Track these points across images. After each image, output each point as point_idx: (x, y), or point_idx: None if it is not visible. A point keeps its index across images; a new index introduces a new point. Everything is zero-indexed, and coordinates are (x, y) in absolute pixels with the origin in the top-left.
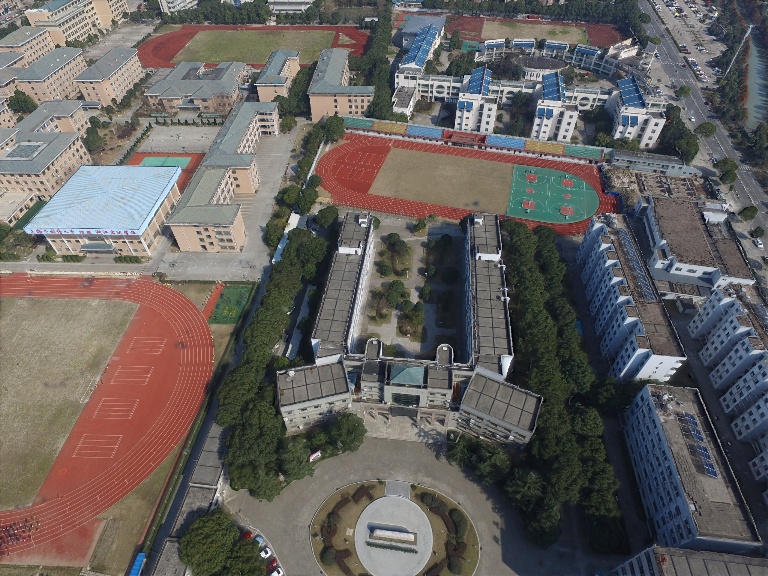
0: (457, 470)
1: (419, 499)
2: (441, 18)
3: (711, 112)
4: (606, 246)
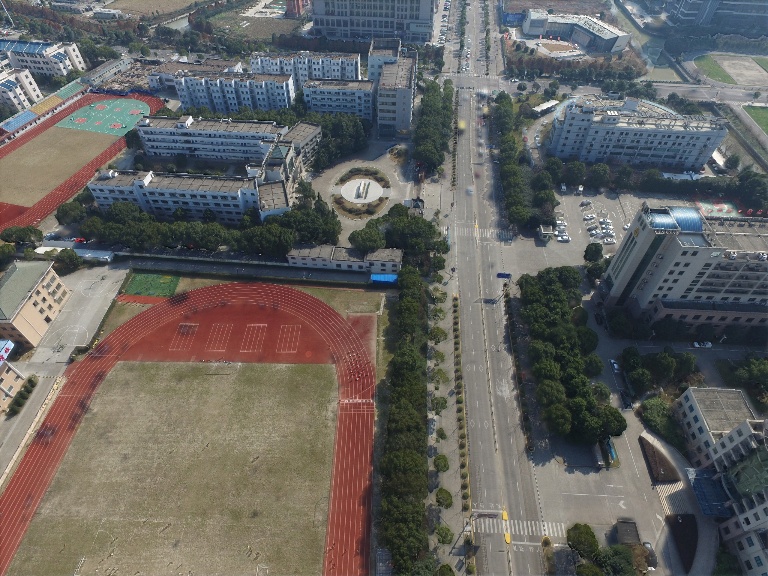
0: (329, 170)
1: (343, 182)
2: None
3: (59, 42)
4: (203, 81)
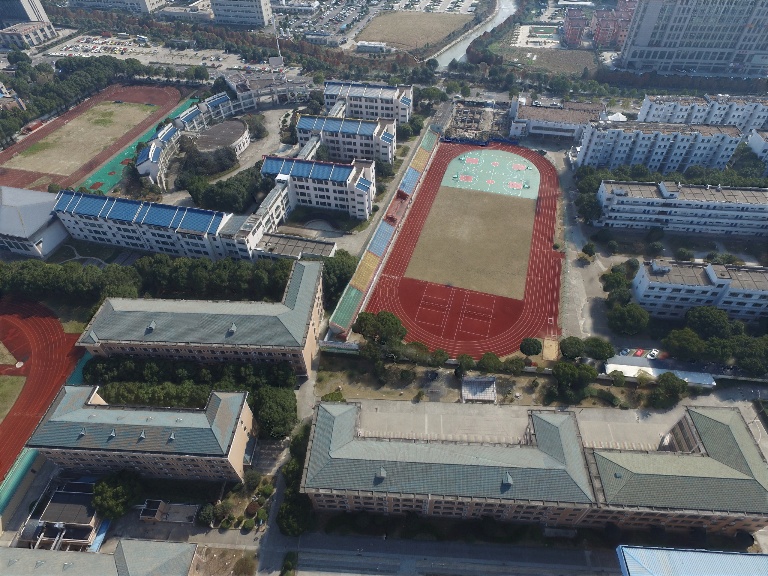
0: None
1: None
2: (3, 190)
3: (346, 80)
4: None
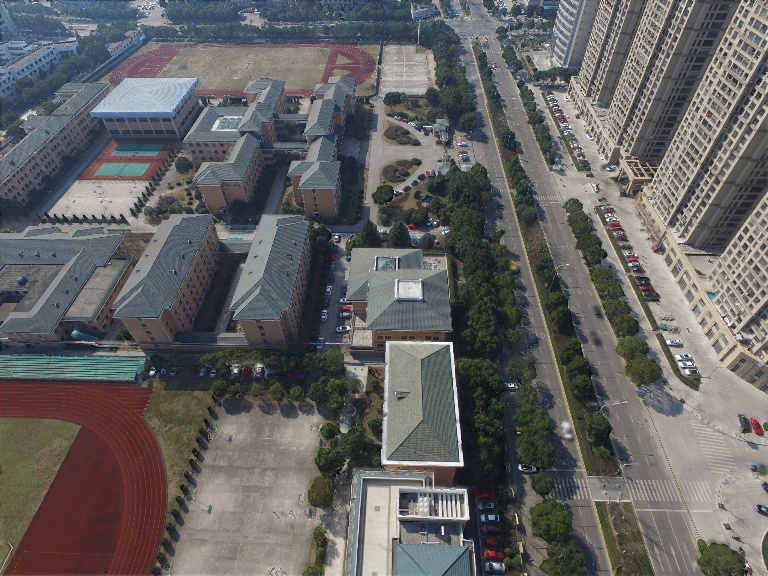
0: None
1: None
2: None
3: None
4: None
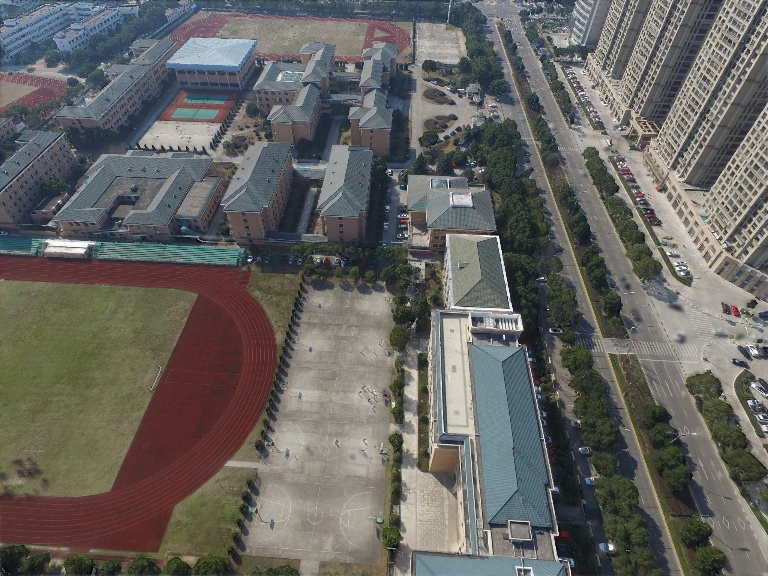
0: None
1: None
2: None
3: None
4: None
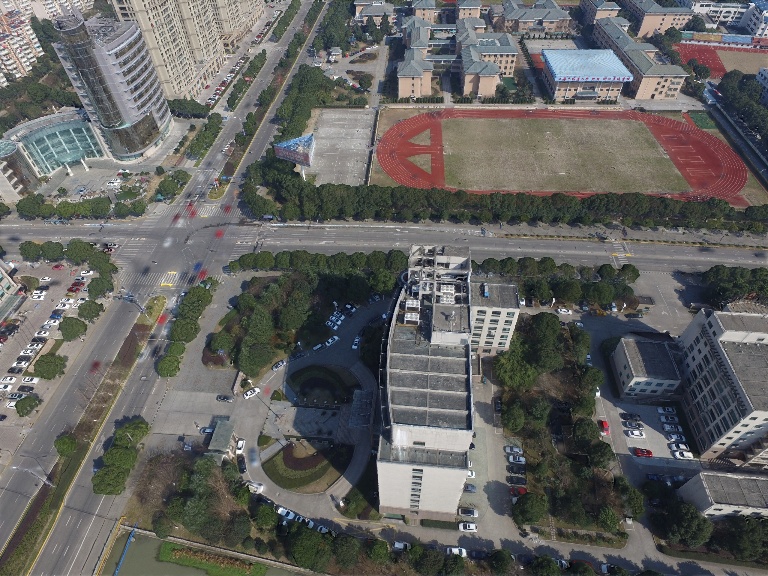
0: None
1: None
2: None
3: None
4: None
